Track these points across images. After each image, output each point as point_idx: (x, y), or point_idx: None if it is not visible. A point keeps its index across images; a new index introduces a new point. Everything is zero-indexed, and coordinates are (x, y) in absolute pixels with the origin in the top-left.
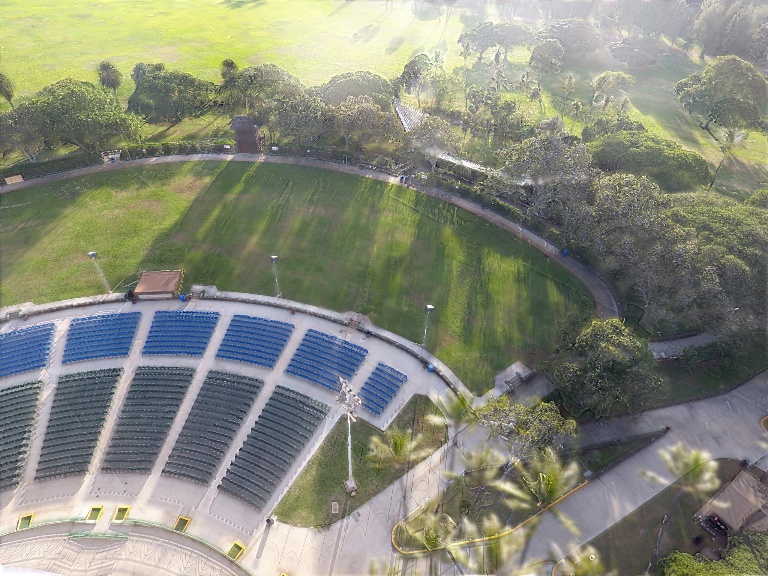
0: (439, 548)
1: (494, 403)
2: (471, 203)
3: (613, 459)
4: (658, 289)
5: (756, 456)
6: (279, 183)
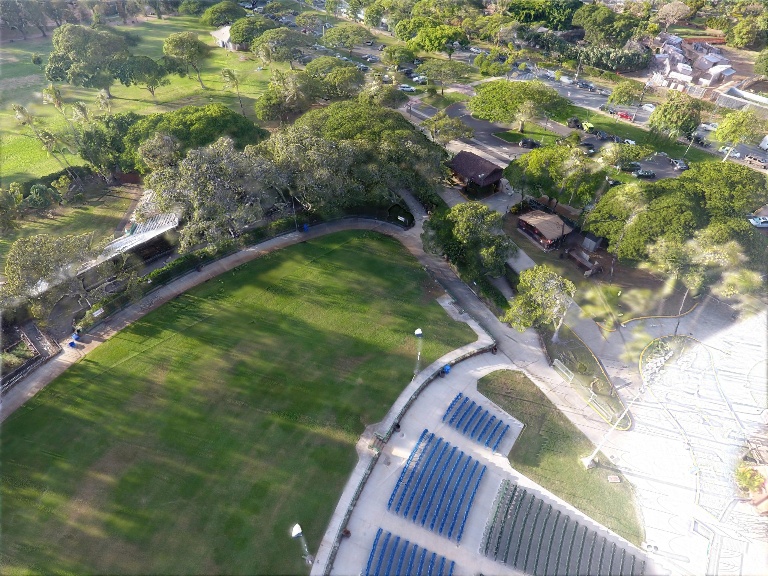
0: (618, 395)
1: (523, 311)
2: (182, 279)
3: (515, 274)
4: (412, 178)
5: None
6: None
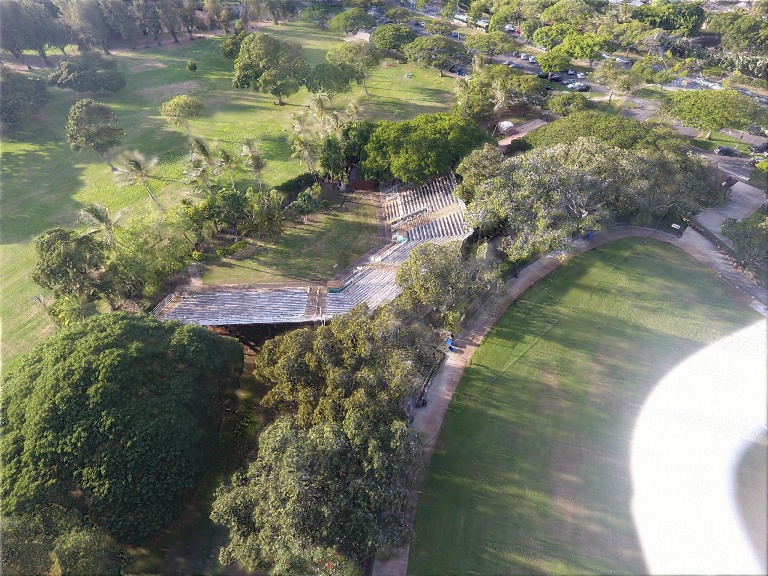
0: None
1: None
2: (506, 285)
3: None
4: None
5: (737, 219)
6: (493, 575)
